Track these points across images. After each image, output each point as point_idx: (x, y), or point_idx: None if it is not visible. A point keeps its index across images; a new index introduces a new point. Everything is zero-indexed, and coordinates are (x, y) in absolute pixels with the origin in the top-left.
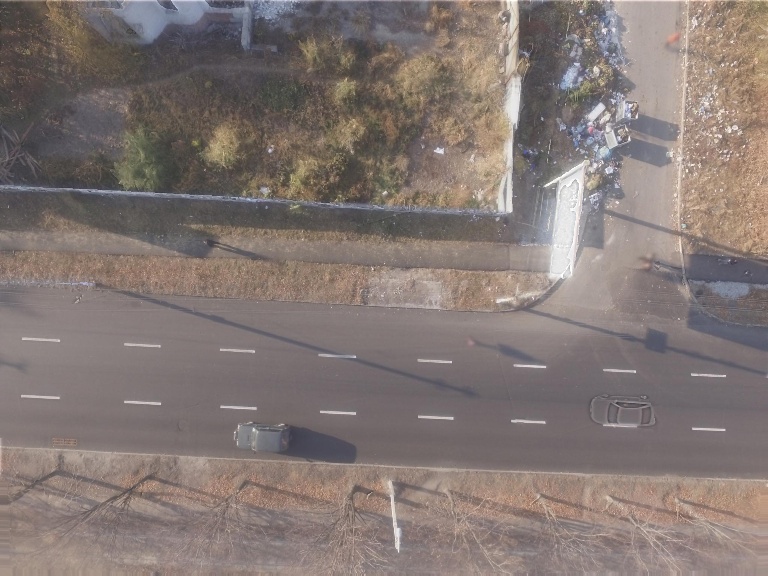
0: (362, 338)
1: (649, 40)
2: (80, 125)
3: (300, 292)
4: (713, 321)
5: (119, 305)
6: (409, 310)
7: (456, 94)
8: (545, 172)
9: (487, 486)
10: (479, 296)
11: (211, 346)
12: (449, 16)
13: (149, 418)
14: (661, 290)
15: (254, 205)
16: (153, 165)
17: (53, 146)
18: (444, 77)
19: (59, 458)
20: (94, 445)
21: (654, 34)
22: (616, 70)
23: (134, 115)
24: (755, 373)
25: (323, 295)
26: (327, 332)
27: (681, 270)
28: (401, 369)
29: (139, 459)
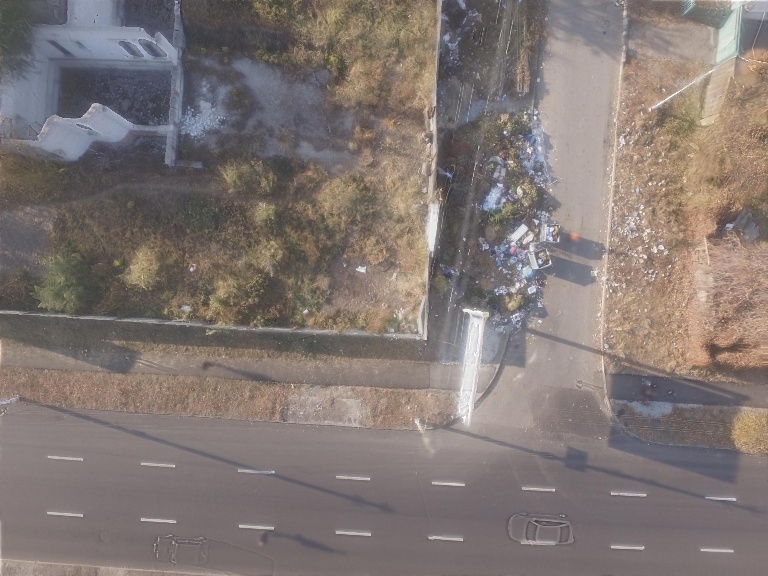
0: (281, 454)
1: (576, 158)
2: (6, 241)
3: (220, 409)
4: (635, 440)
5: (43, 418)
6: (328, 427)
7: (379, 213)
8: (467, 292)
9: None
10: (398, 415)
11: (132, 460)
12: (372, 136)
13: (71, 529)
14: (583, 409)
15: None
16: (73, 288)
17: None
18: (367, 196)
19: None
20: (18, 554)
21: (581, 152)
22: (541, 189)
23: (57, 234)
24: (677, 492)
25: (243, 412)
26: (247, 448)
27: (603, 390)
28: (320, 485)
29: (61, 569)
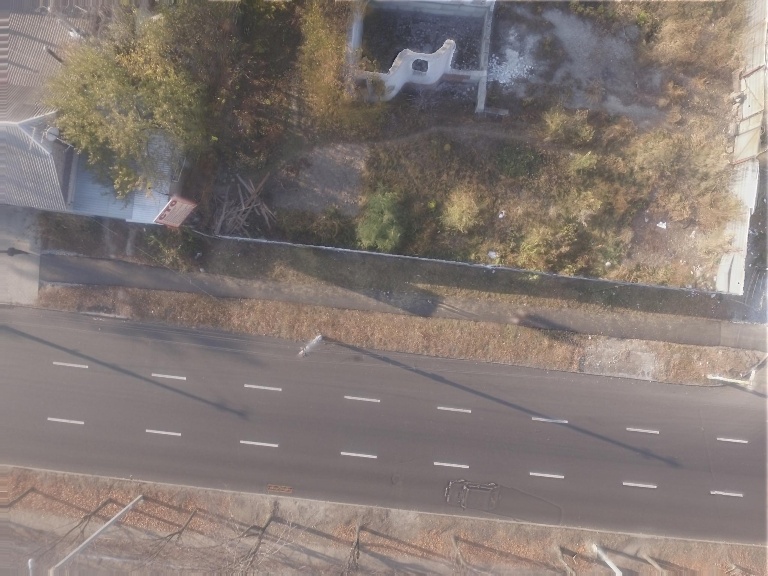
0: (575, 404)
1: None
2: (315, 178)
3: (519, 356)
4: None
5: (342, 358)
6: (622, 379)
7: (682, 170)
8: (762, 252)
9: (685, 554)
10: (690, 370)
11: (429, 404)
12: (684, 93)
13: (364, 470)
14: None
15: (483, 269)
16: (395, 226)
17: (288, 198)
18: (673, 153)
19: (275, 504)
20: (309, 493)
21: None
22: None
23: (372, 173)
24: None
25: (541, 361)
26: (542, 397)
27: None
28: (610, 436)
29: (352, 510)
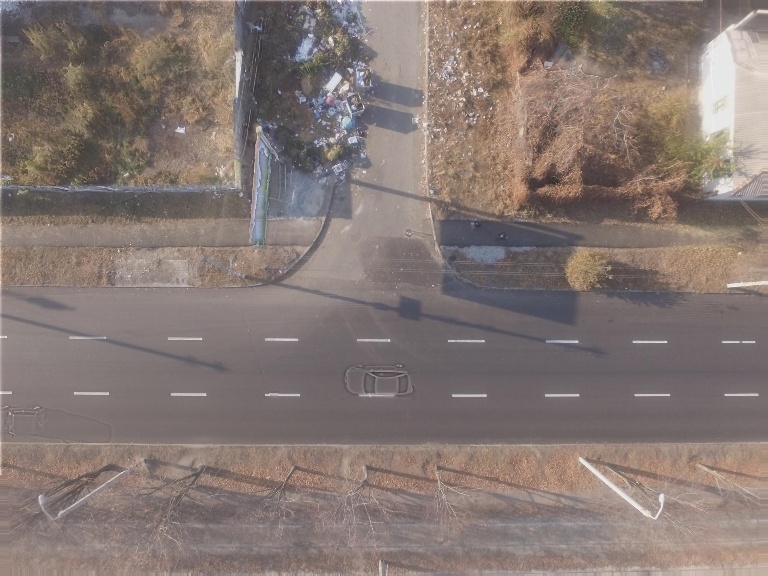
0: (112, 319)
1: (389, 7)
2: None
3: (47, 276)
4: (469, 286)
5: None
6: (157, 289)
7: (194, 73)
8: (286, 145)
9: (242, 460)
10: (225, 272)
11: None
12: None
13: None
14: (414, 258)
15: None
16: None
17: None
18: (180, 57)
19: None
20: None
21: (394, 1)
22: (356, 39)
23: None
24: (516, 337)
25: (70, 278)
26: (77, 315)
27: (432, 236)
28: (152, 348)
29: None
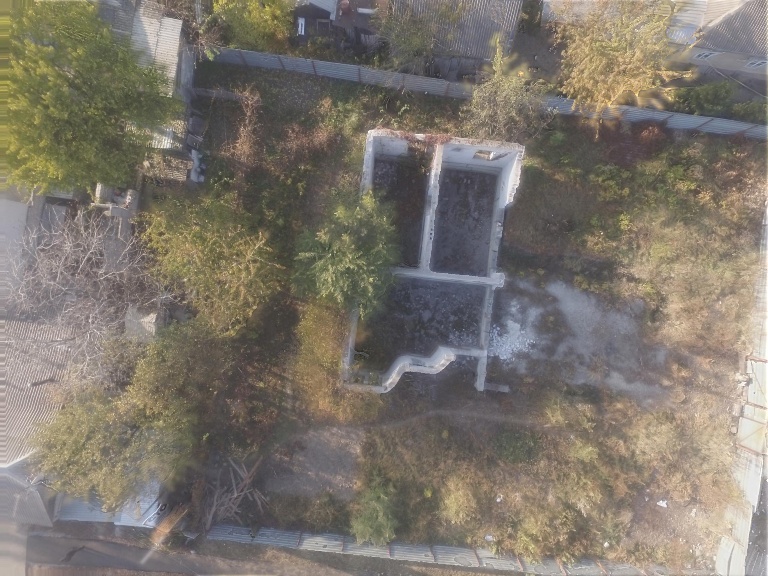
0: None
1: None
2: (310, 462)
3: None
4: None
5: None
6: None
7: (684, 448)
8: (763, 530)
9: None
10: None
11: None
12: (689, 376)
13: None
14: None
15: None
16: (390, 523)
17: (281, 482)
18: (676, 433)
19: None
20: None
21: None
22: None
23: (368, 460)
24: None
25: None
26: None
27: None
28: None
29: None
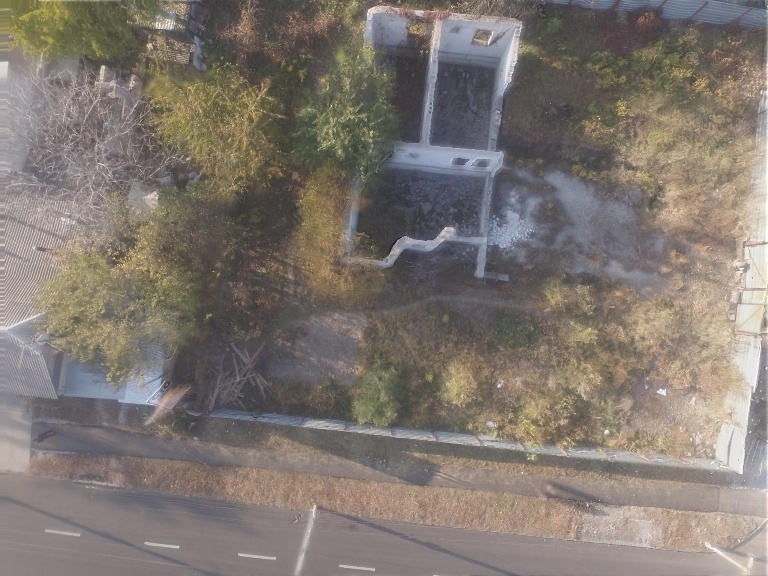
0: (571, 572)
1: None
2: (311, 347)
3: (516, 525)
4: None
5: (337, 527)
6: (619, 547)
7: (683, 337)
8: (763, 419)
9: None
10: (688, 537)
11: (424, 572)
12: (687, 262)
13: None
14: None
15: None
16: (392, 404)
17: (284, 367)
18: (675, 321)
19: None
20: None
21: None
22: None
23: (369, 344)
24: None
25: (538, 529)
26: (538, 564)
27: None
28: None
29: None
